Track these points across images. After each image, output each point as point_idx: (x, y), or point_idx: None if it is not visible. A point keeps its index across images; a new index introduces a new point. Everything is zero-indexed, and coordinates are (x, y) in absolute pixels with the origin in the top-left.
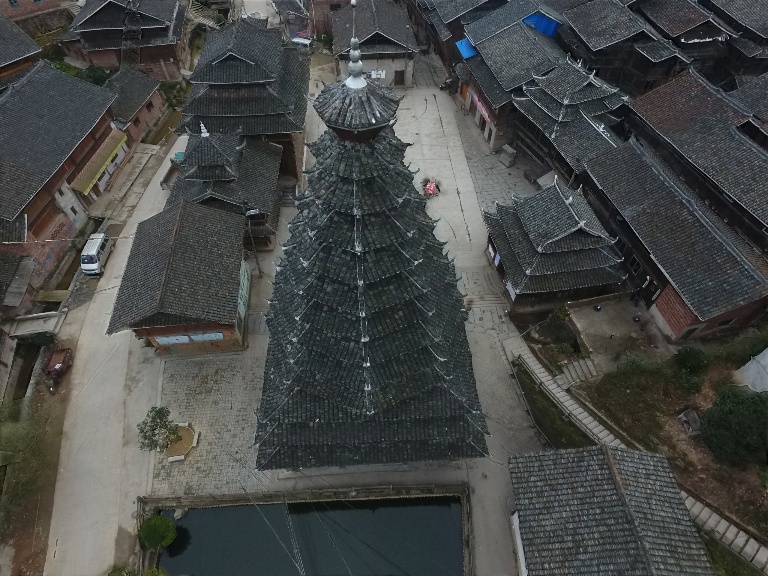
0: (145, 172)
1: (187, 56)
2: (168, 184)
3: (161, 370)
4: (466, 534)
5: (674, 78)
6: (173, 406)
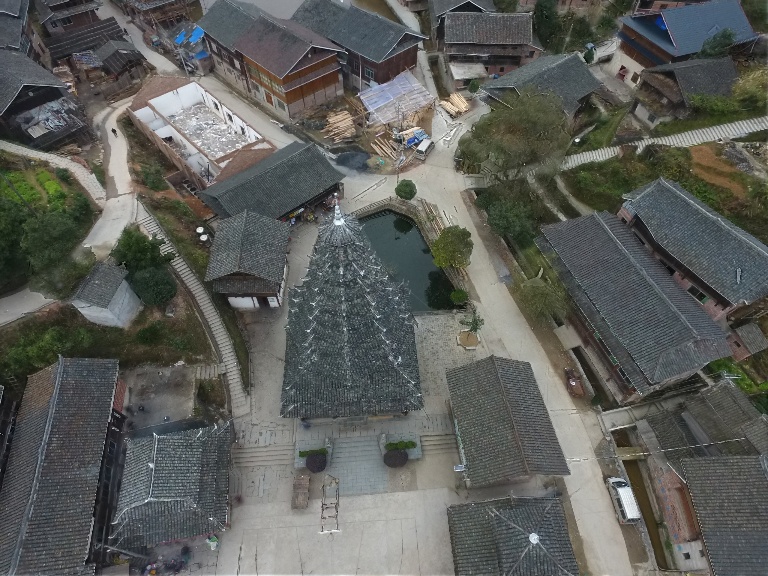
0: None
1: None
2: None
3: None
4: None
5: None
6: None
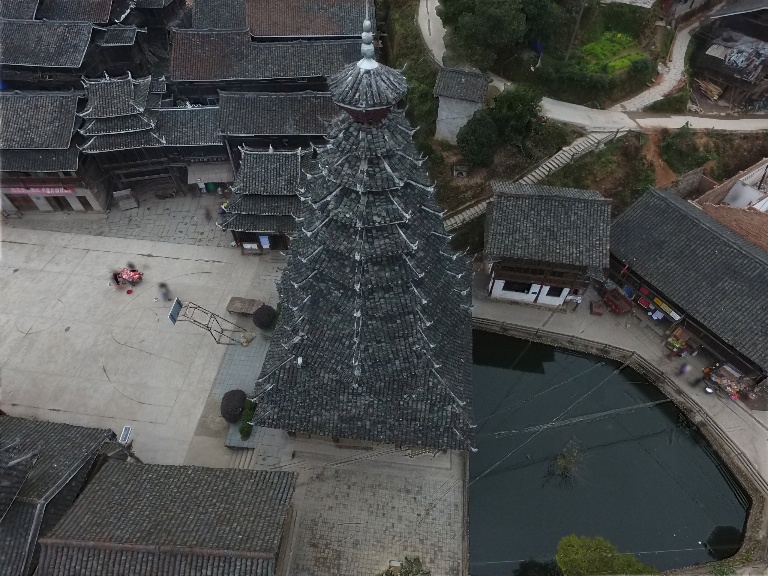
0: None
1: None
2: None
3: None
4: (499, 329)
5: (171, 42)
6: None
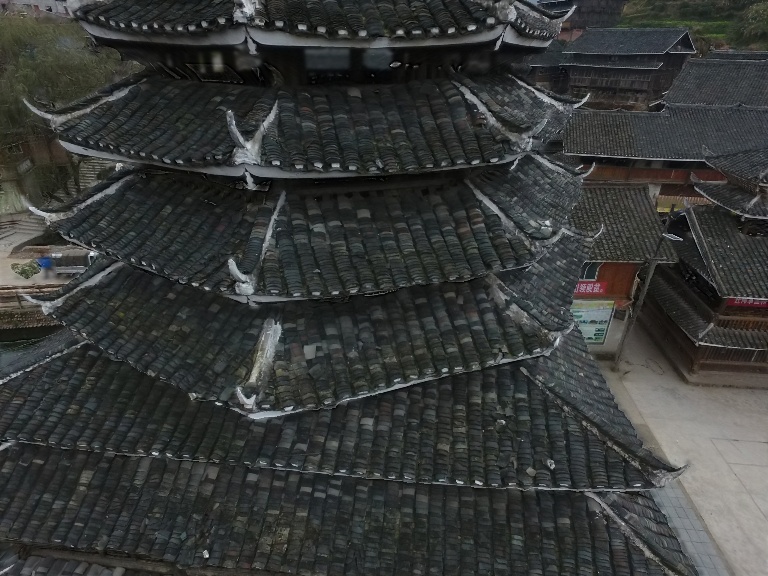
0: None
1: None
2: None
3: None
4: None
5: None
6: None
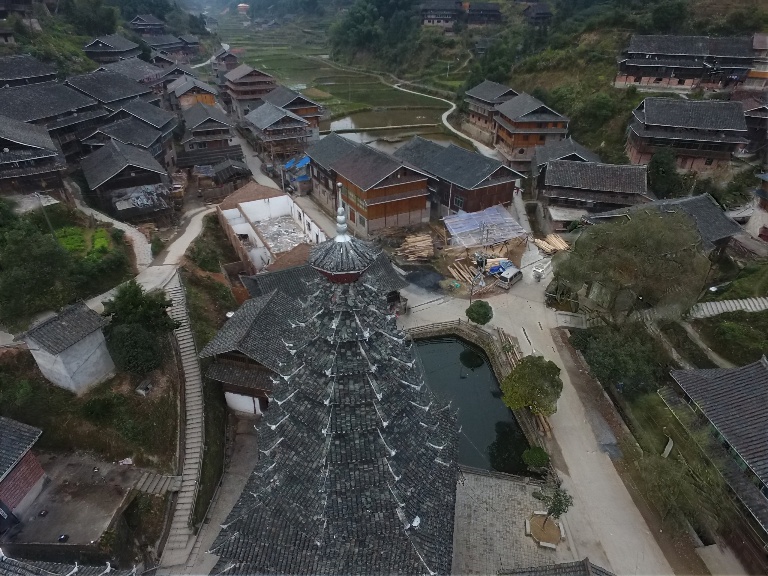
0: None
1: None
2: None
3: None
4: None
5: None
6: None
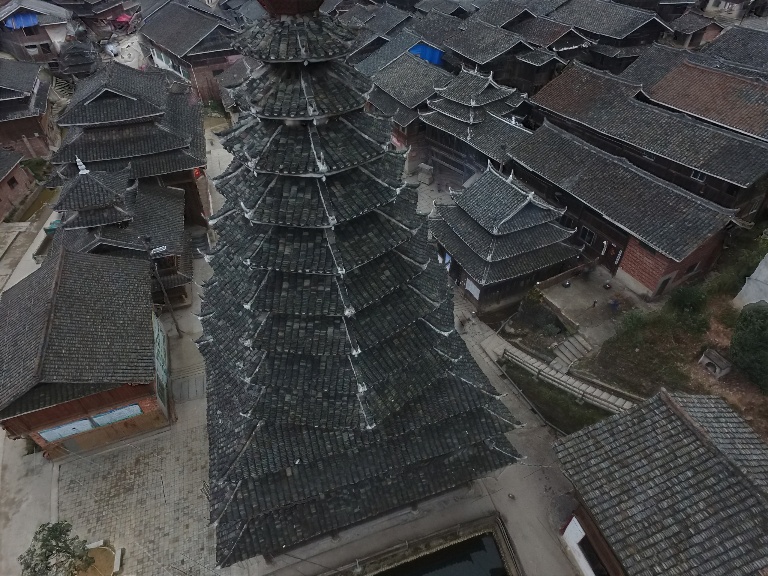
0: (12, 252)
1: (56, 135)
2: (43, 255)
3: (54, 478)
4: None
5: (562, 72)
6: (77, 523)
